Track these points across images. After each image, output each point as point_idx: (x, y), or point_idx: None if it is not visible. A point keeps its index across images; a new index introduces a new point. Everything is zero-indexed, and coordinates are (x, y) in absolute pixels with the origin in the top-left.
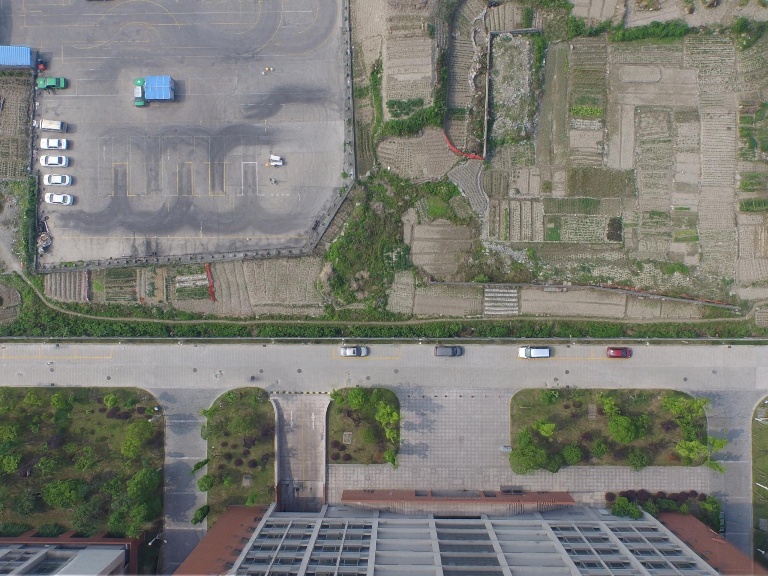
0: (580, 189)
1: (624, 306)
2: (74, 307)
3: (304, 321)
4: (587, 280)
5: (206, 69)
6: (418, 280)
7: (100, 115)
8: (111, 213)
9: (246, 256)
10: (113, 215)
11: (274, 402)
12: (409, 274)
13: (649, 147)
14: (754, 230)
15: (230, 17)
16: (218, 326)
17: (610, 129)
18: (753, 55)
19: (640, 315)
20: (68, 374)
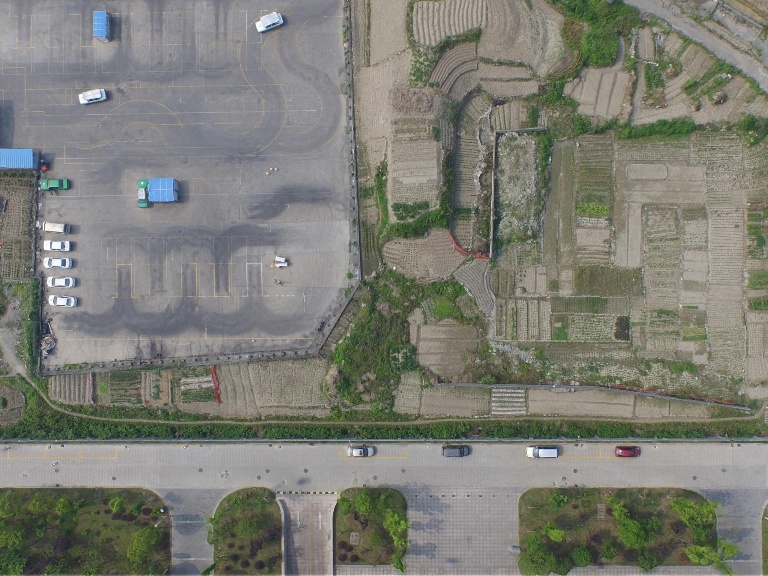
0: (587, 288)
1: (632, 406)
2: (79, 409)
3: (310, 422)
4: (595, 380)
5: (210, 169)
6: (425, 381)
7: (103, 216)
8: (115, 315)
9: (251, 357)
10: (117, 317)
11: (281, 503)
12: (416, 375)
13: (656, 245)
14: (763, 328)
15: (233, 117)
16: (224, 427)
17: (617, 227)
18: (760, 151)
19: (649, 415)
20: (73, 475)
